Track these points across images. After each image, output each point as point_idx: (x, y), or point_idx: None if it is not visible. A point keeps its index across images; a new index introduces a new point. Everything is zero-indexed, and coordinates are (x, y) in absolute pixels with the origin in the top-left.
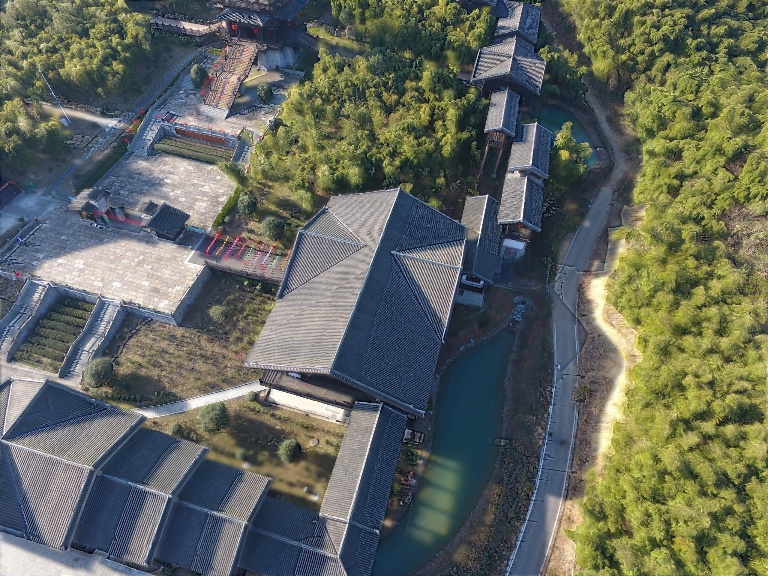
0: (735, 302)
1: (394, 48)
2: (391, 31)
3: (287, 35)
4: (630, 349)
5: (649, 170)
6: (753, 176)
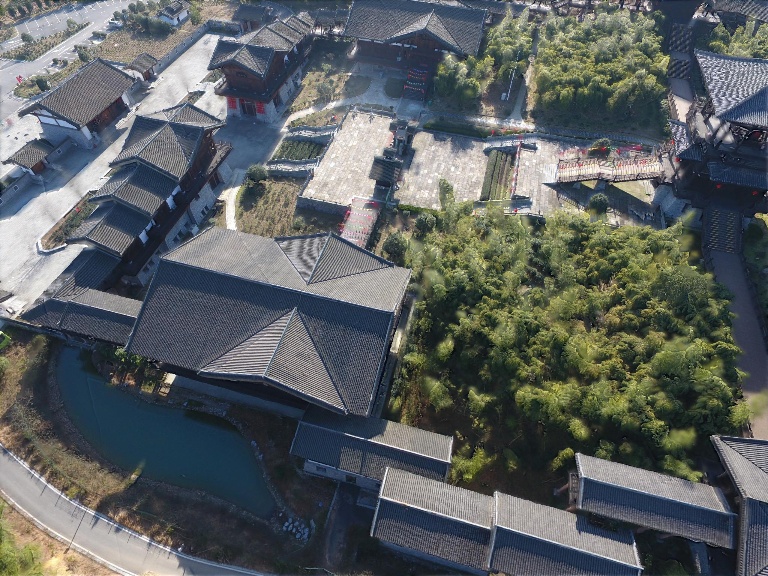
0: None
1: None
2: None
3: (709, 195)
4: None
5: None
6: None
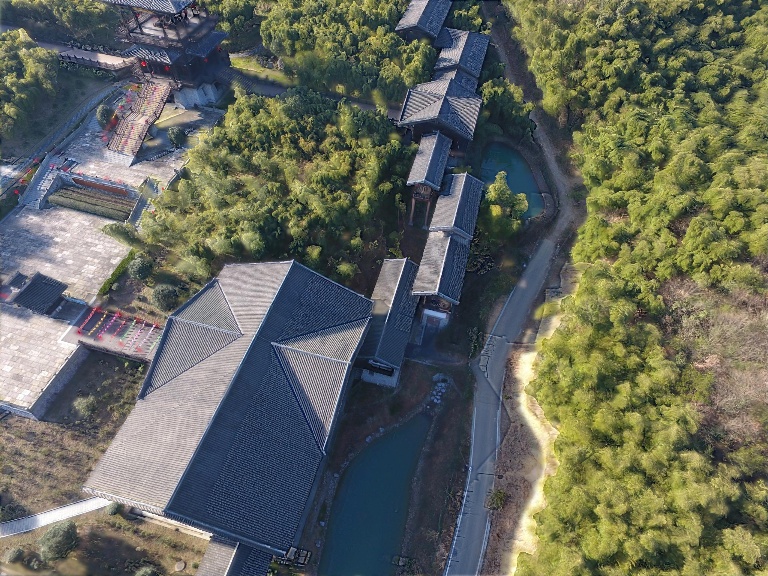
0: (665, 402)
1: (324, 84)
2: (319, 66)
3: (206, 71)
4: (552, 448)
5: (588, 228)
6: (696, 242)
